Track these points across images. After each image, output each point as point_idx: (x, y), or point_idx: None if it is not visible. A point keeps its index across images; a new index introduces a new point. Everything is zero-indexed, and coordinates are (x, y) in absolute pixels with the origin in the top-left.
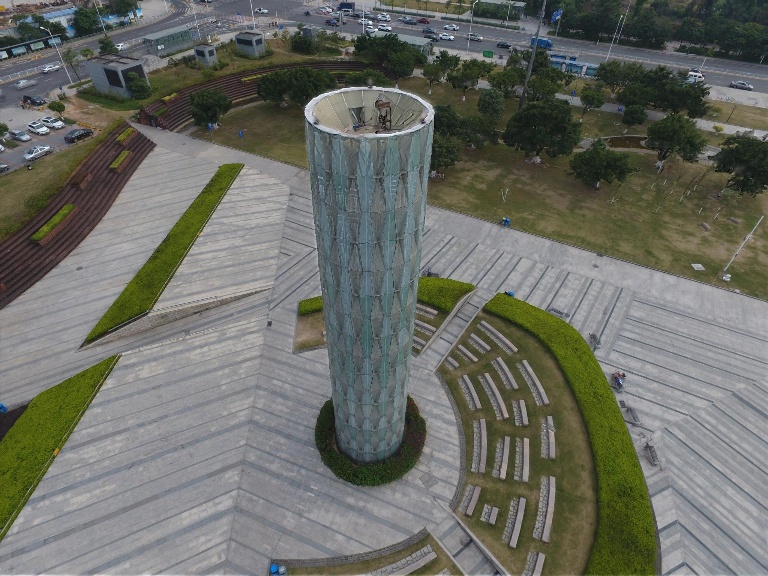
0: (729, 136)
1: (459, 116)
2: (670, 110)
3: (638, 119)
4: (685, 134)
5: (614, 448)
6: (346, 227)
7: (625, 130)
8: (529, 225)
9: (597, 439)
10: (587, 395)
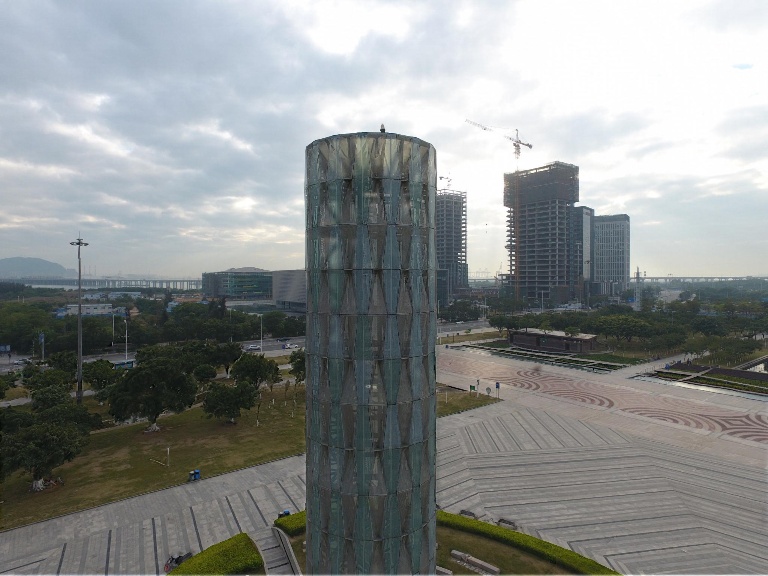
0: (290, 356)
1: (32, 414)
2: (222, 366)
3: (211, 373)
4: (266, 362)
5: (501, 530)
6: (418, 249)
7: (201, 388)
8: (218, 468)
9: (492, 531)
10: (443, 517)
